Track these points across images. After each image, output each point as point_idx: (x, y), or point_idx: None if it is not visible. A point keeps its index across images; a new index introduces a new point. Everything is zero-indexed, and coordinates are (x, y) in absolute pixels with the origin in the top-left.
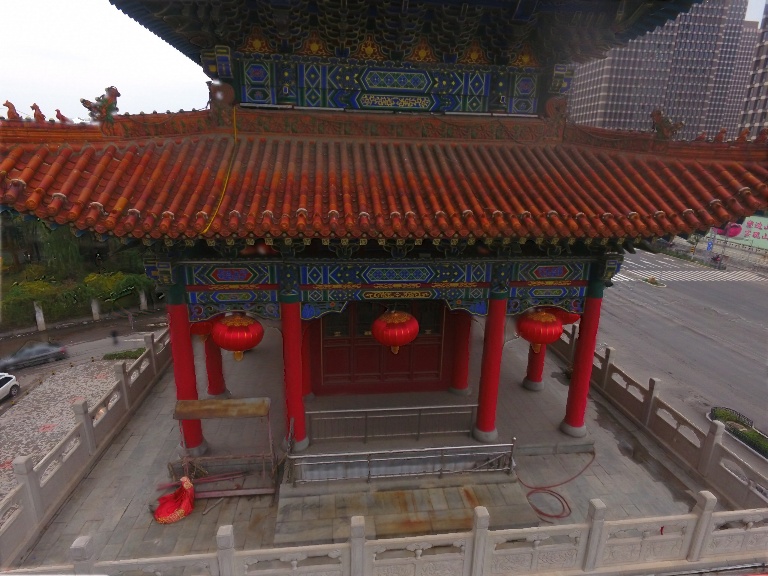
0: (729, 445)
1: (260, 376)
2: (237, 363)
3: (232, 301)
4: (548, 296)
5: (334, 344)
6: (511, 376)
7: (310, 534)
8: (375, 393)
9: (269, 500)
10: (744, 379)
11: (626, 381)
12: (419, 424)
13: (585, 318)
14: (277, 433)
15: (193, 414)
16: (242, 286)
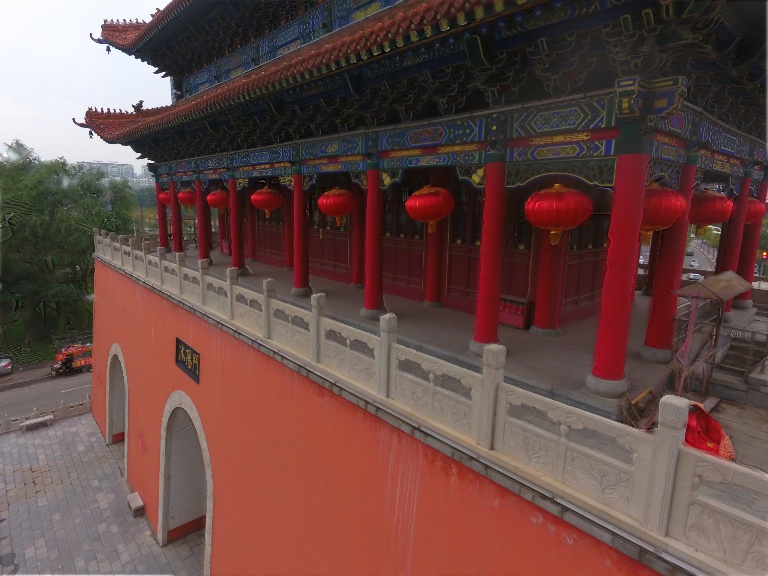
0: None
1: (464, 329)
2: (407, 327)
3: (667, 159)
4: (755, 178)
5: (573, 261)
6: None
7: None
8: (590, 316)
9: (729, 406)
10: None
11: (704, 275)
12: (703, 313)
13: (759, 200)
14: None
15: (727, 293)
16: (670, 140)
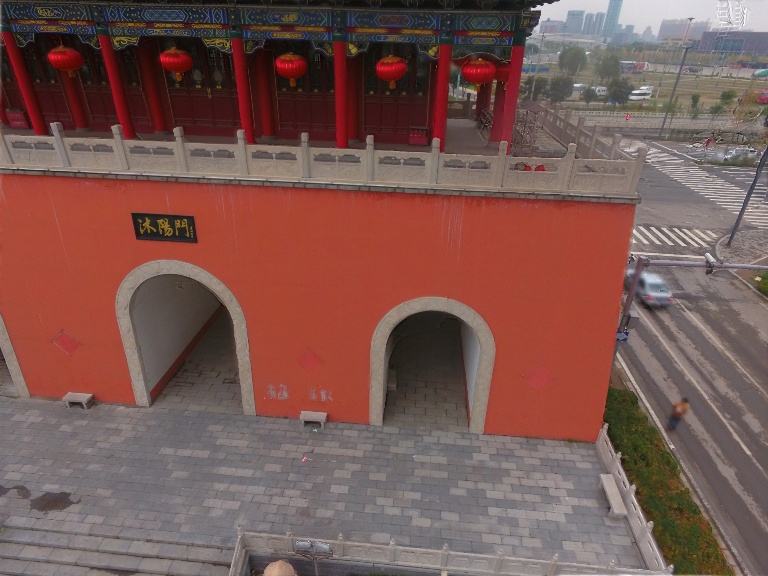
0: None
1: None
2: None
3: None
4: None
5: None
6: None
7: (560, 146)
8: None
9: None
10: None
11: (450, 103)
12: None
13: None
14: None
15: None
16: None
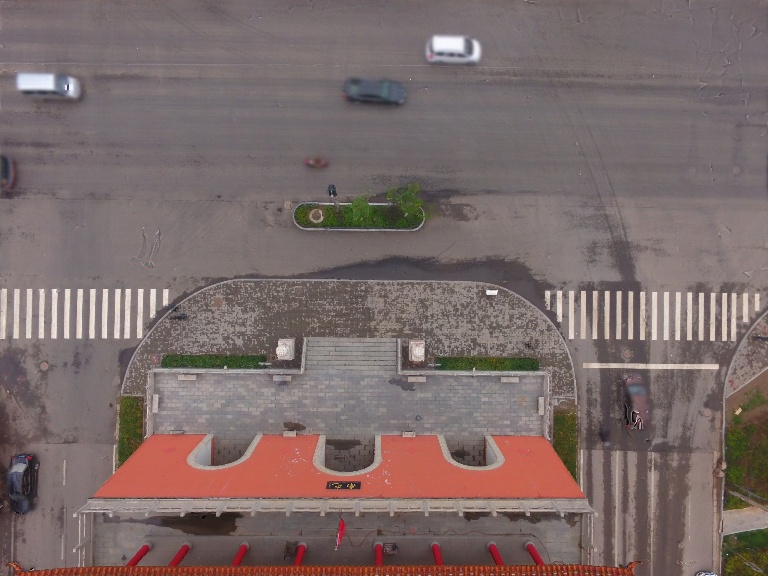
0: (335, 241)
1: None
2: None
3: None
4: None
5: None
6: (480, 552)
7: None
8: None
9: None
10: (240, 132)
11: None
12: None
13: None
14: None
15: None
16: None
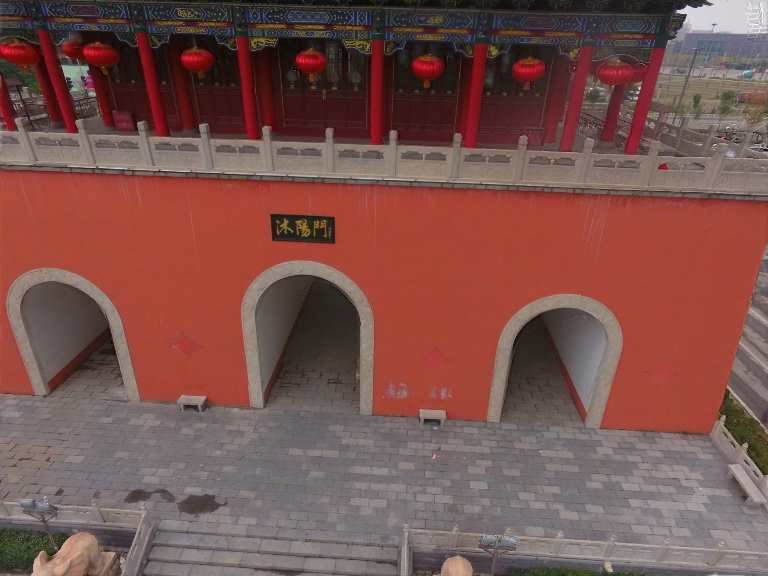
0: None
1: None
2: None
3: None
4: None
5: None
6: None
7: None
8: None
9: None
10: None
11: None
12: None
13: None
14: (595, 149)
15: None
16: None
